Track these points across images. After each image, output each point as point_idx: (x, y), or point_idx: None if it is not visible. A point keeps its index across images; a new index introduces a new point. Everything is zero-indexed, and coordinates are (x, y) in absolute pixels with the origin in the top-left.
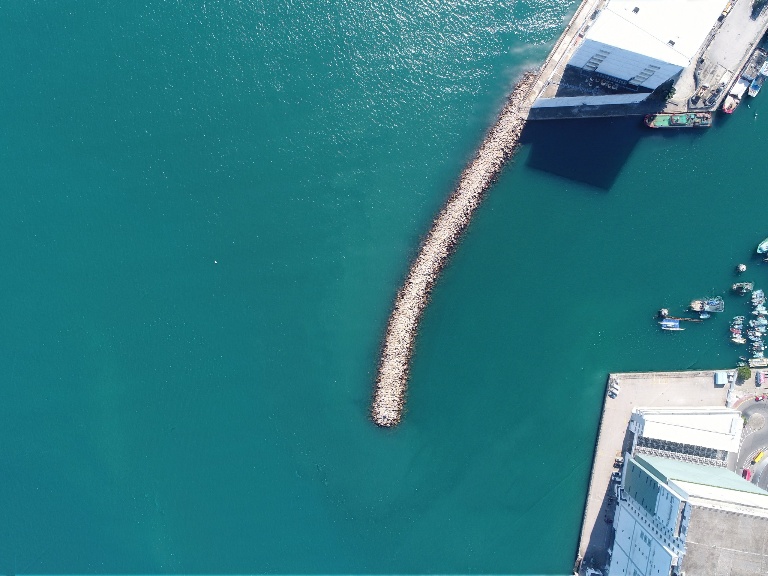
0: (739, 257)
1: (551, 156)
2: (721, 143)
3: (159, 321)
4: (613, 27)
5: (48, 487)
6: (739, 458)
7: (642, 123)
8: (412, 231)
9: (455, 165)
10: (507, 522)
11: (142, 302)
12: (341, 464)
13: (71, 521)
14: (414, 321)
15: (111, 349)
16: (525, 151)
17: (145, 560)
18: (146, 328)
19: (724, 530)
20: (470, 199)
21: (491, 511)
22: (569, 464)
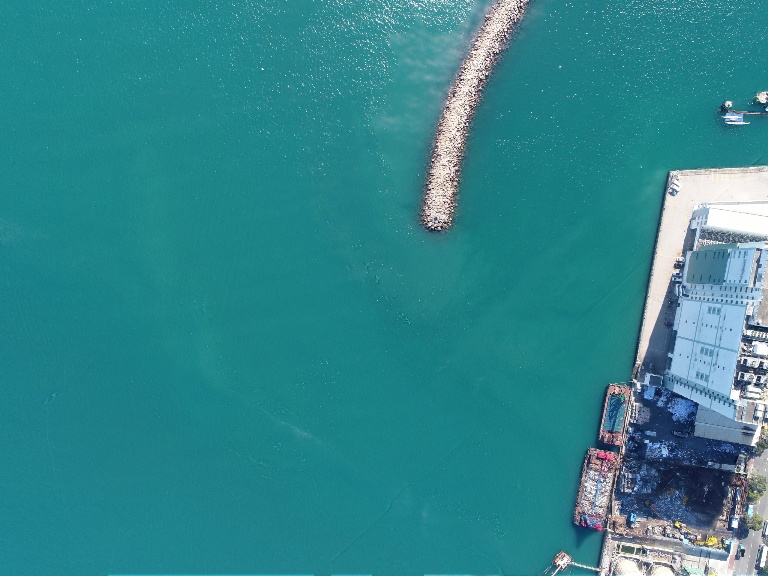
0: None
1: None
2: None
3: (208, 111)
4: None
5: (96, 298)
6: None
7: None
8: (463, 28)
9: None
10: (562, 328)
11: (190, 93)
12: (393, 258)
13: (119, 330)
14: (465, 120)
15: (160, 141)
16: None
17: (192, 377)
18: (195, 118)
19: None
20: None
21: (545, 317)
22: (627, 267)
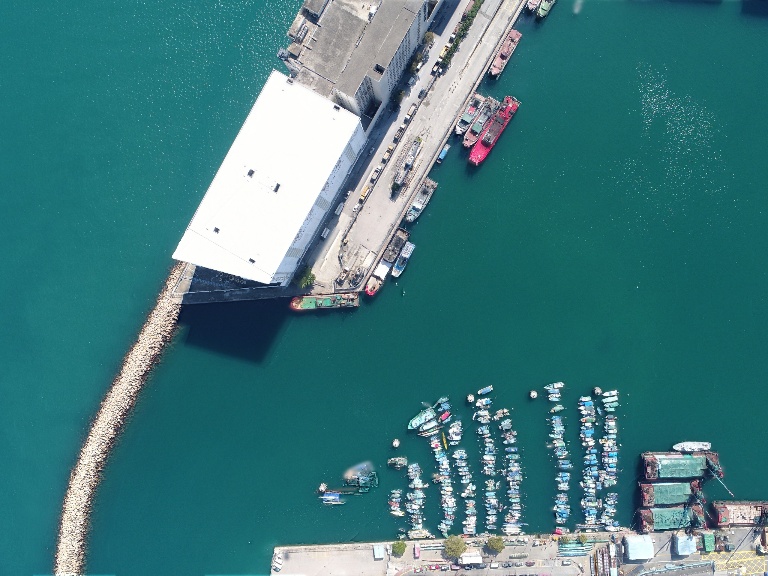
0: (394, 432)
1: (210, 337)
2: (371, 321)
3: None
4: (197, 246)
5: None
6: None
7: (288, 306)
8: (83, 412)
9: (120, 347)
10: None
11: None
12: None
13: None
14: (87, 499)
15: None
16: (185, 332)
17: None
18: None
19: None
20: (131, 382)
21: None
22: None
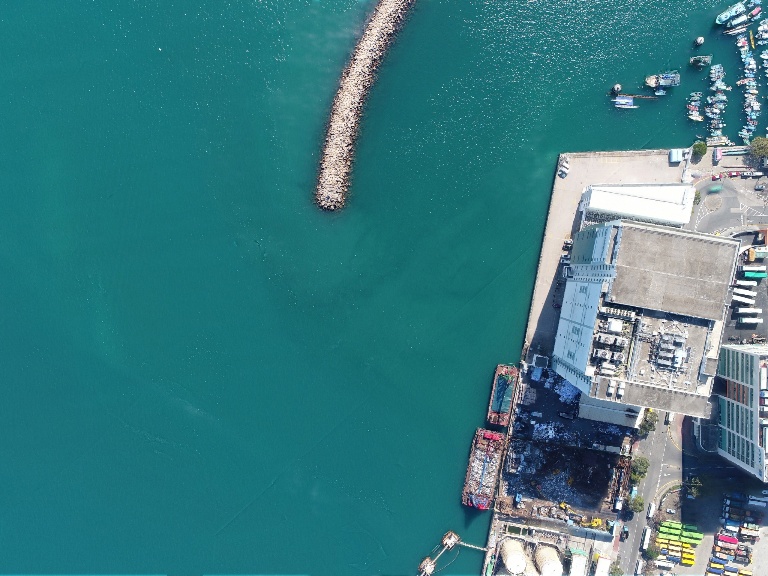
0: (697, 30)
1: None
2: None
3: (98, 86)
4: None
5: None
6: None
7: None
8: (358, 9)
9: None
10: (453, 309)
11: (82, 68)
12: (280, 235)
13: (17, 304)
14: (359, 100)
15: (50, 115)
16: None
17: (92, 353)
18: (85, 93)
19: (657, 252)
20: None
21: (436, 297)
22: (517, 249)
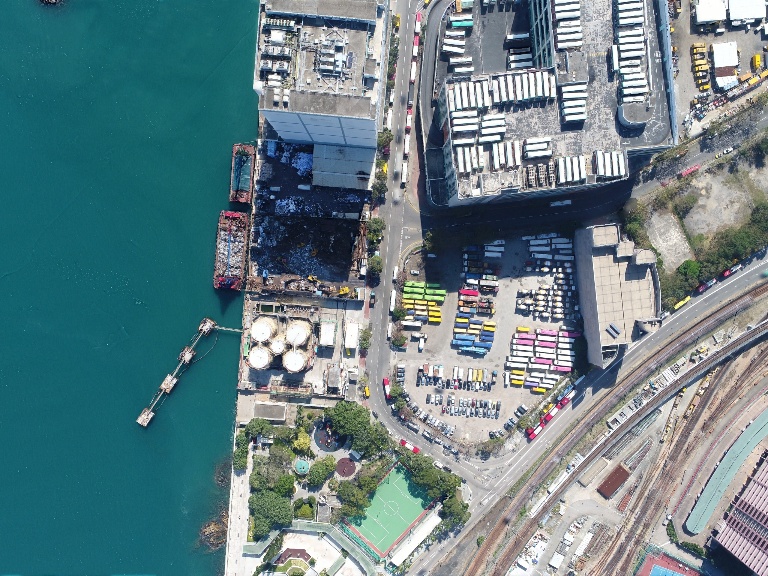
0: None
1: None
2: None
3: None
4: None
5: None
6: (411, 3)
7: None
8: None
9: None
10: (186, 94)
11: None
12: None
13: None
14: None
15: None
16: None
17: None
18: None
19: None
20: None
21: (168, 84)
22: (243, 28)
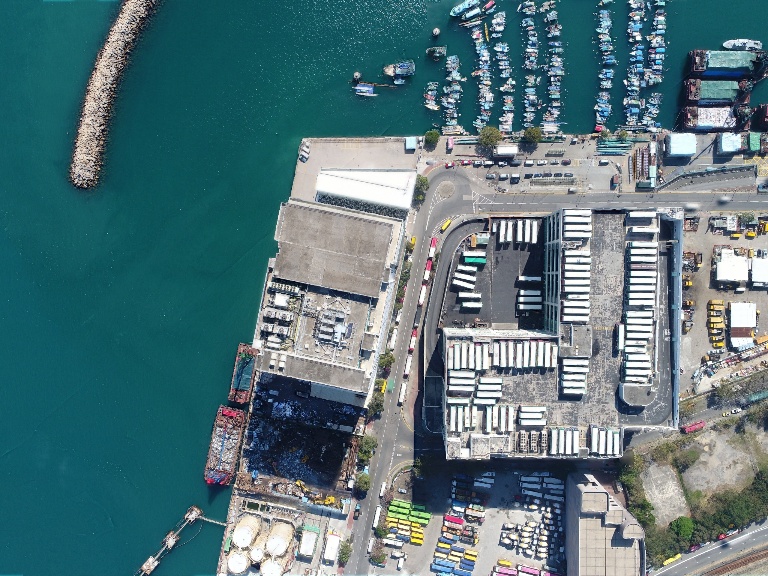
0: (435, 22)
1: None
2: None
3: None
4: None
5: None
6: (428, 226)
7: None
8: None
9: None
10: (200, 288)
11: None
12: (20, 210)
13: None
14: (112, 82)
15: None
16: None
17: None
18: None
19: (318, 230)
20: None
21: (184, 276)
22: (262, 230)
